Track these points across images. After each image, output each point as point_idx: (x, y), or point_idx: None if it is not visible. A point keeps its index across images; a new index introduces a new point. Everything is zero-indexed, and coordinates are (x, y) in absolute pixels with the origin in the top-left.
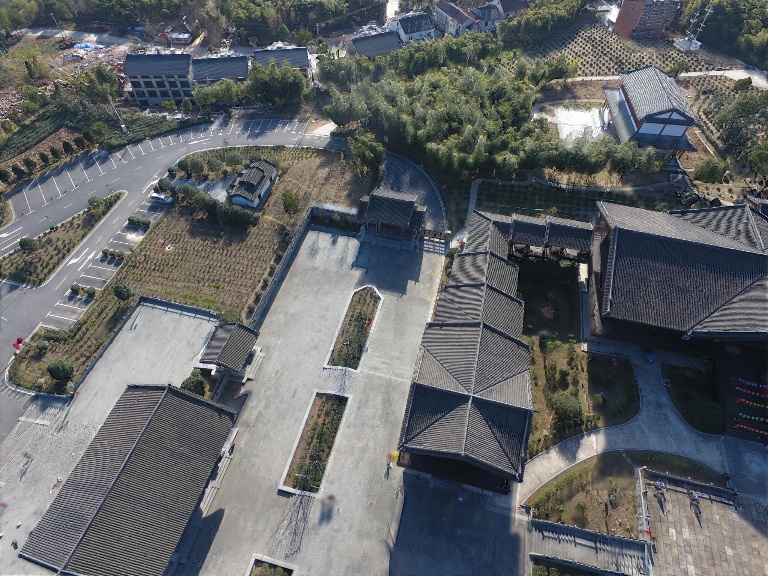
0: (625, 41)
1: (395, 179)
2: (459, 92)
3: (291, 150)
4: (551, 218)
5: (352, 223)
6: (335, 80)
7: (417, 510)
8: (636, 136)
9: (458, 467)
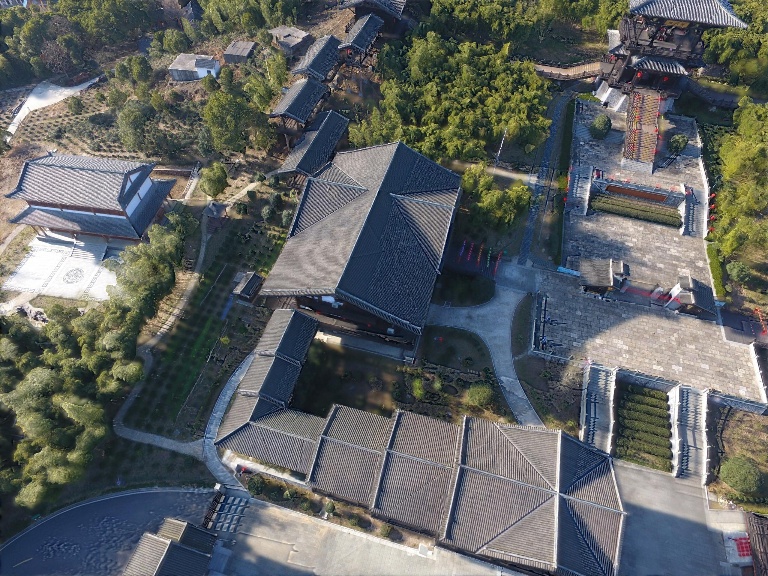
0: None
1: (50, 575)
2: None
3: None
4: (262, 348)
5: None
6: None
7: None
8: (133, 221)
9: None
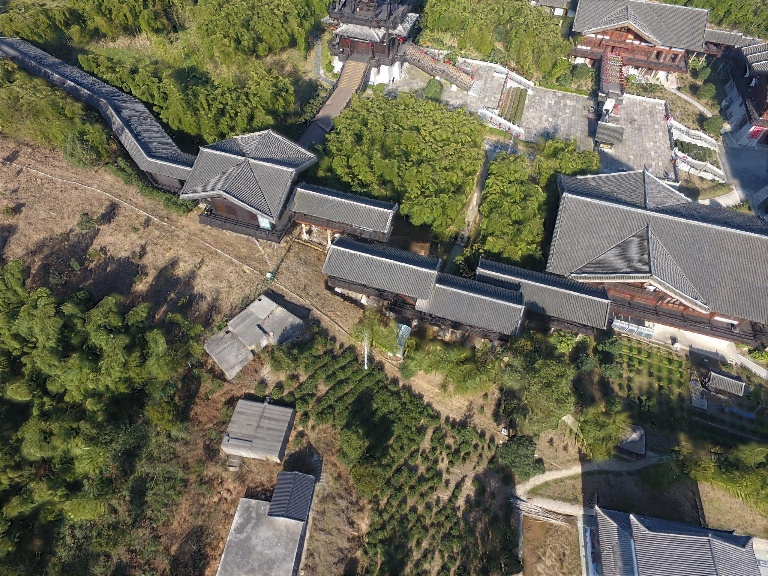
0: None
1: None
2: None
3: None
4: None
5: None
6: None
7: None
8: None
9: None
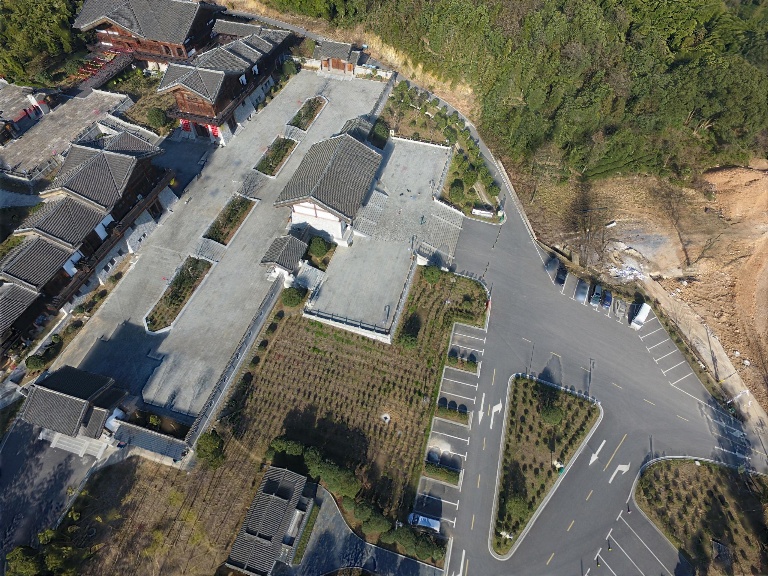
0: None
1: (32, 534)
2: None
3: None
4: None
5: None
6: None
7: (179, 185)
8: None
9: None
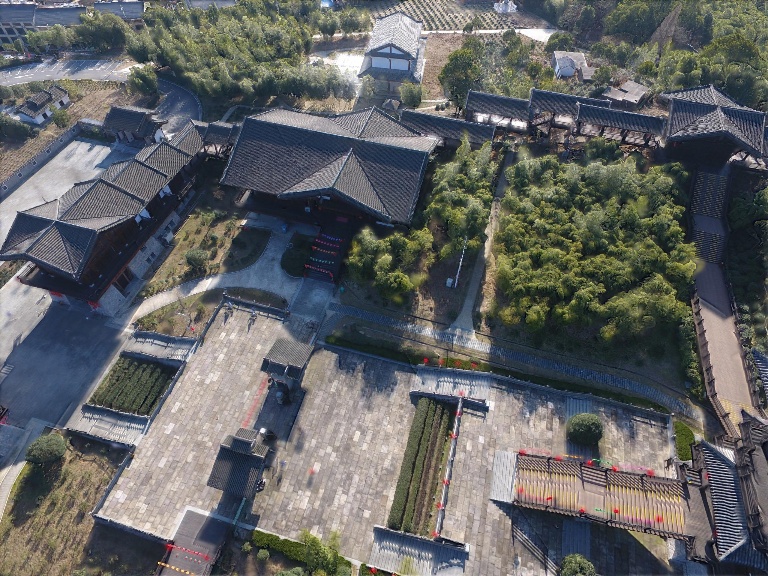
0: (451, 4)
1: (169, 105)
2: (242, 35)
3: (96, 83)
4: None
5: (112, 136)
6: (154, 27)
7: (49, 324)
8: (370, 70)
9: (64, 283)
